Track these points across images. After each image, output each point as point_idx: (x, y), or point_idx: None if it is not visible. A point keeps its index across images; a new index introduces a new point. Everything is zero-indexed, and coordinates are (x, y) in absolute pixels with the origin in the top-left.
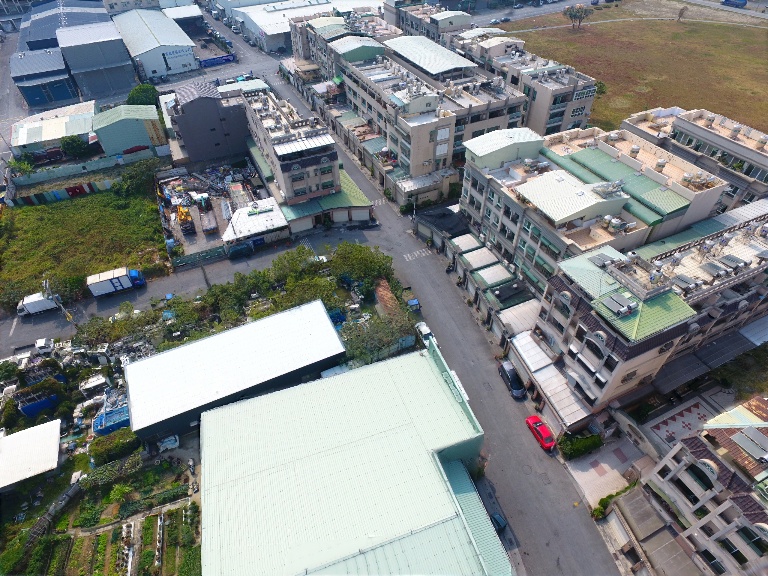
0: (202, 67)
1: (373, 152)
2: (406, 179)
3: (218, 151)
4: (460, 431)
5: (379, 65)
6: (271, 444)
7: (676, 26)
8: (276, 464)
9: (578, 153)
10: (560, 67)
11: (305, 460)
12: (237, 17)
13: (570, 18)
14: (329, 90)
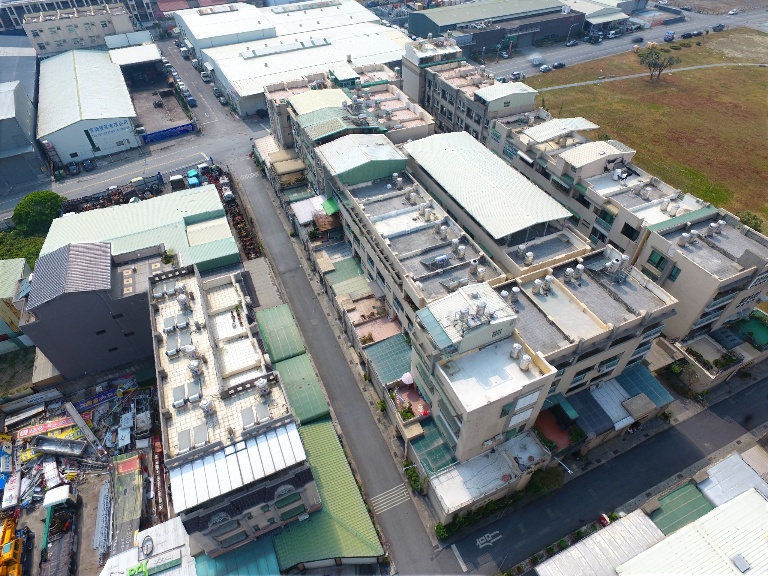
0: (147, 143)
1: (385, 383)
2: (449, 468)
3: (116, 357)
4: None
5: (397, 192)
6: None
7: None
8: None
9: None
10: (710, 212)
11: None
12: (206, 62)
13: (648, 67)
14: (316, 220)
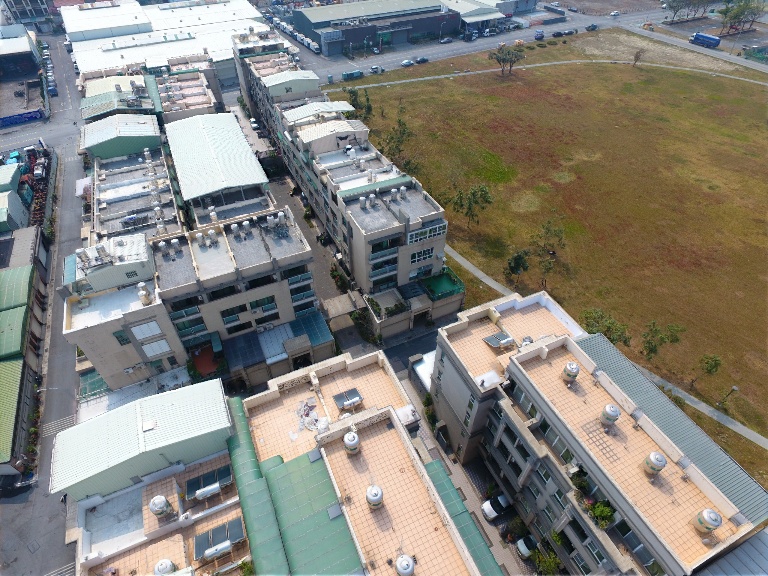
0: None
1: None
2: (100, 394)
3: None
4: None
5: (143, 165)
6: None
7: (630, 73)
8: None
9: (279, 471)
10: (403, 180)
11: None
12: None
13: (498, 62)
14: (87, 193)
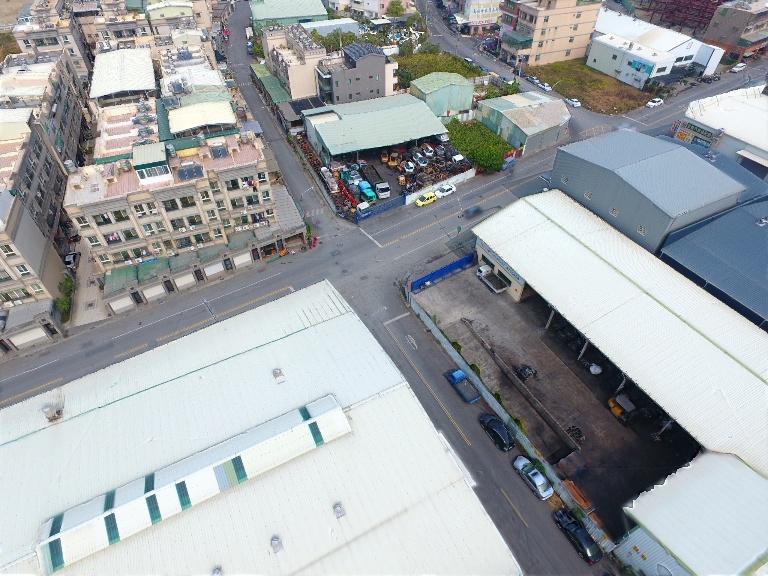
0: (467, 264)
1: None
2: None
3: None
4: (254, 5)
5: None
6: (306, 7)
7: None
8: (304, 5)
9: None
10: None
11: (297, 5)
12: None
13: None
14: None
